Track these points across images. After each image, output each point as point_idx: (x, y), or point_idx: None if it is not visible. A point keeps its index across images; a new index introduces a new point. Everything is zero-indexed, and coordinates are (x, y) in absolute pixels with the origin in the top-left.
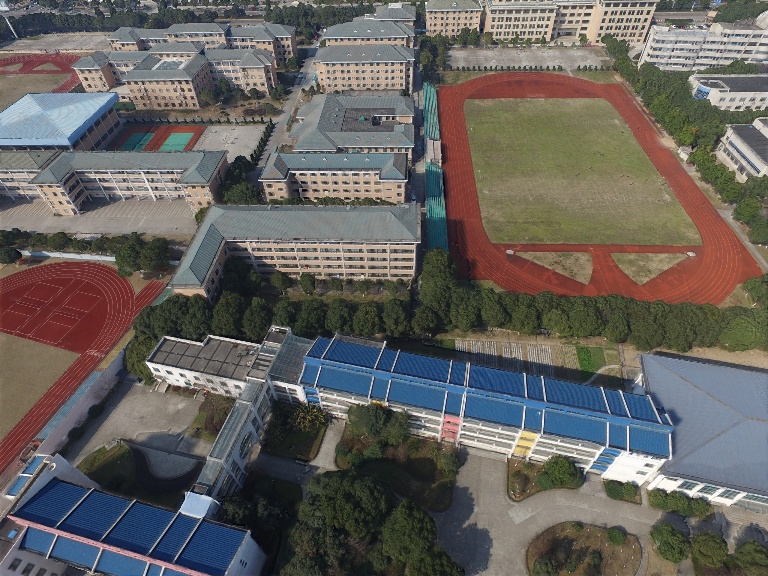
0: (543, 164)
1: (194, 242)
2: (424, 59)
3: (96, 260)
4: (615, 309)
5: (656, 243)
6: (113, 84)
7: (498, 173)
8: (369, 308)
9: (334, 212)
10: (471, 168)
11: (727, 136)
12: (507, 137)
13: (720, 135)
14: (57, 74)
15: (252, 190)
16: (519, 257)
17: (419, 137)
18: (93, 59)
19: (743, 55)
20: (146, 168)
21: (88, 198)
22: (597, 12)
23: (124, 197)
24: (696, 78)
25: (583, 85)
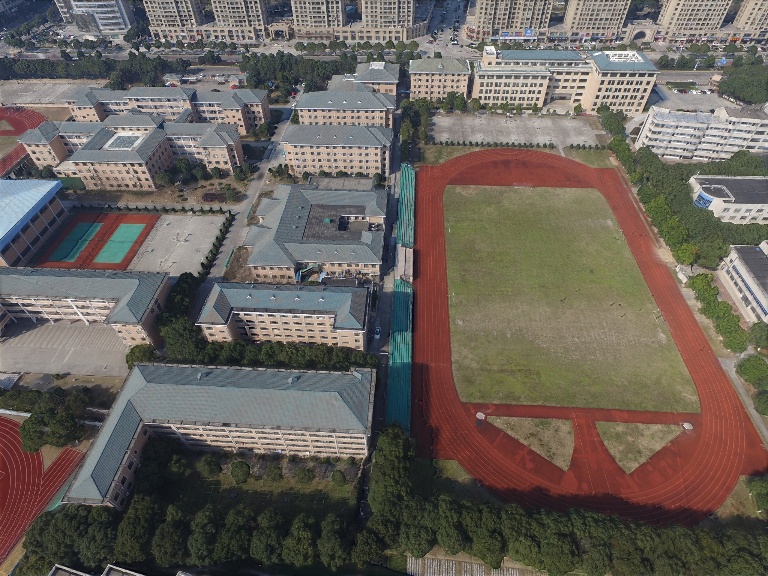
0: (525, 283)
1: (105, 427)
2: (404, 133)
3: (7, 414)
4: (595, 537)
5: (648, 408)
6: (64, 156)
7: (475, 295)
8: (302, 533)
9: (272, 390)
10: (445, 286)
11: (731, 259)
12: (488, 242)
13: (723, 256)
14: (9, 136)
15: (190, 330)
16: (490, 425)
17: (391, 239)
18: (40, 132)
19: (749, 143)
20: (73, 297)
21: (12, 320)
22: (593, 80)
23: (53, 319)
24: (698, 180)
25: (575, 169)
